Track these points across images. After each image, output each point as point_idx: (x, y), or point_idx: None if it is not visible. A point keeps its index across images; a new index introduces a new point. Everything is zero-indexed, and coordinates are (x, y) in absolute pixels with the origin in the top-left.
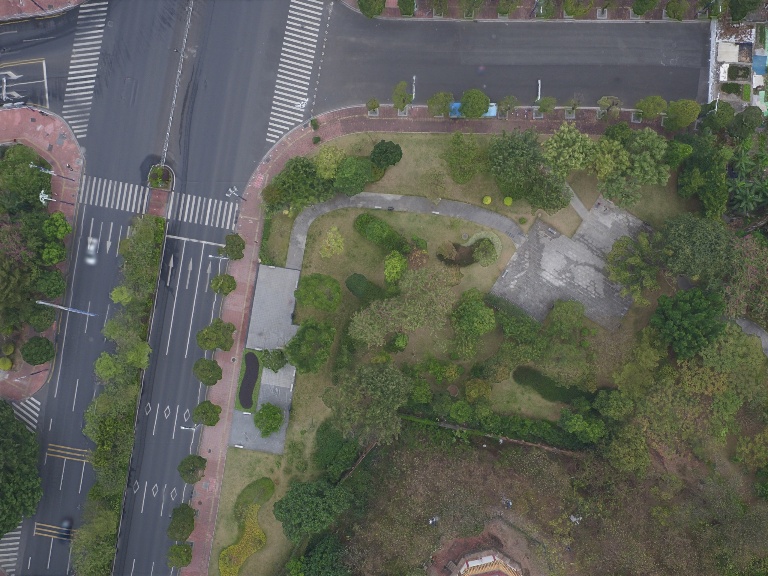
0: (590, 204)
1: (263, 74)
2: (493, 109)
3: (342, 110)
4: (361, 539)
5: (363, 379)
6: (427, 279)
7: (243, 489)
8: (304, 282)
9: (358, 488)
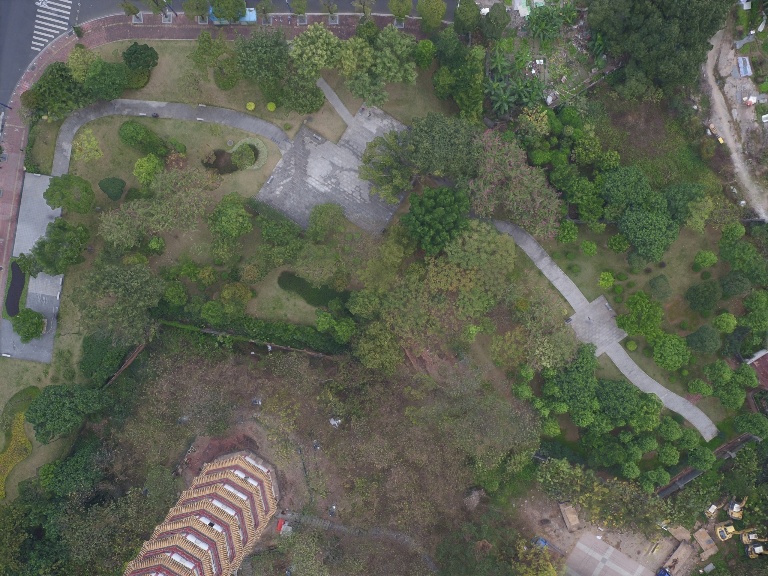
0: (355, 110)
1: None
2: (252, 14)
3: (106, 18)
4: (119, 443)
5: (106, 277)
6: (175, 179)
7: (10, 398)
8: (52, 182)
9: (122, 394)
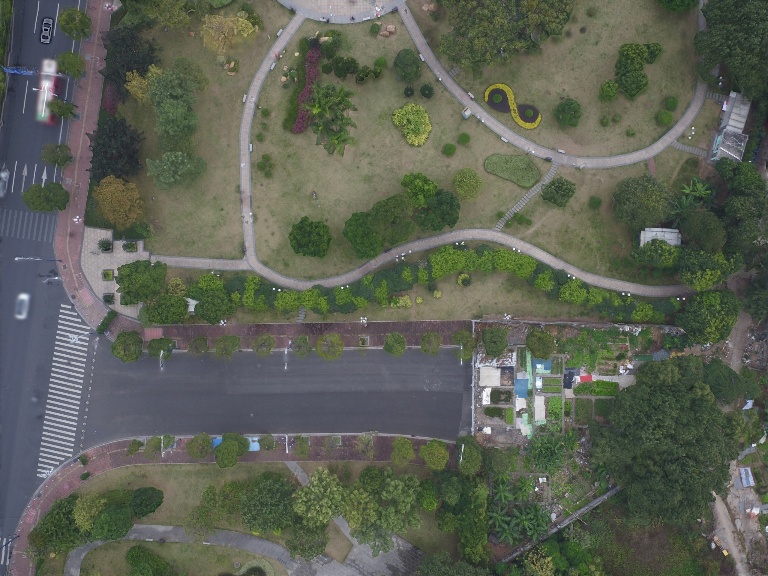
0: None
1: (31, 411)
2: (256, 445)
3: (111, 444)
4: None
5: None
6: None
7: None
8: None
9: None
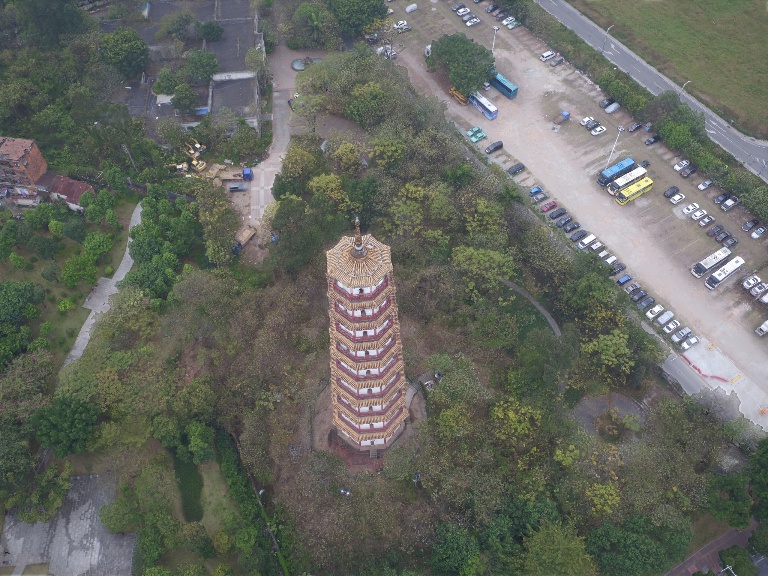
0: (8, 570)
1: None
2: None
3: None
4: None
5: None
6: None
7: None
8: None
9: (377, 575)
